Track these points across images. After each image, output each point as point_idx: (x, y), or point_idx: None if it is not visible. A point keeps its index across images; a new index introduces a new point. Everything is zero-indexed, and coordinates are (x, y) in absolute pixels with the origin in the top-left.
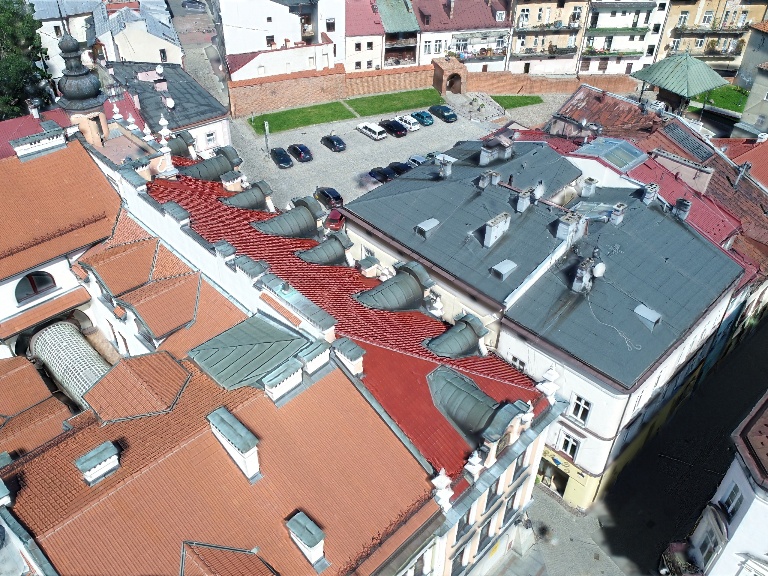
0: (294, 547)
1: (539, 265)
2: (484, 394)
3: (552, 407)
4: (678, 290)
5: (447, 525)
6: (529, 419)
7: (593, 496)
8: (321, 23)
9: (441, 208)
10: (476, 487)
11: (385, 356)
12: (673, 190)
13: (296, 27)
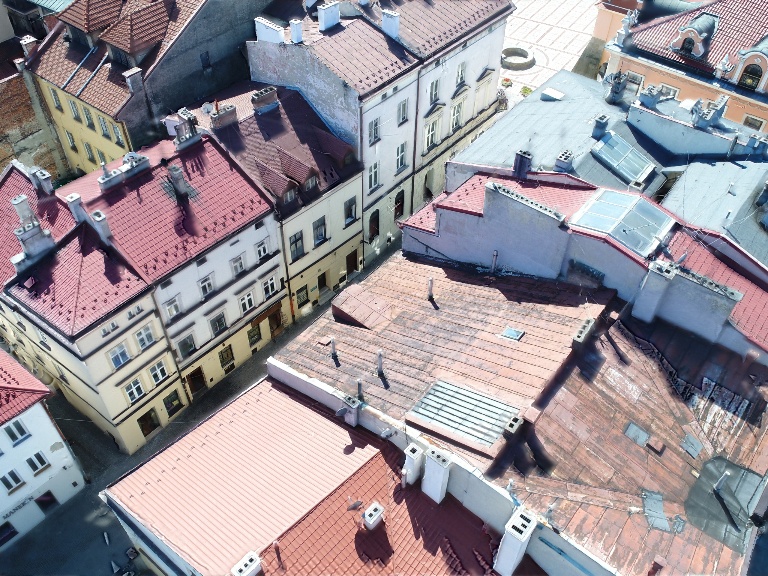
0: None
1: None
2: (665, 3)
3: None
4: (524, 122)
5: None
6: None
7: None
8: None
9: None
10: None
11: None
12: None
13: None
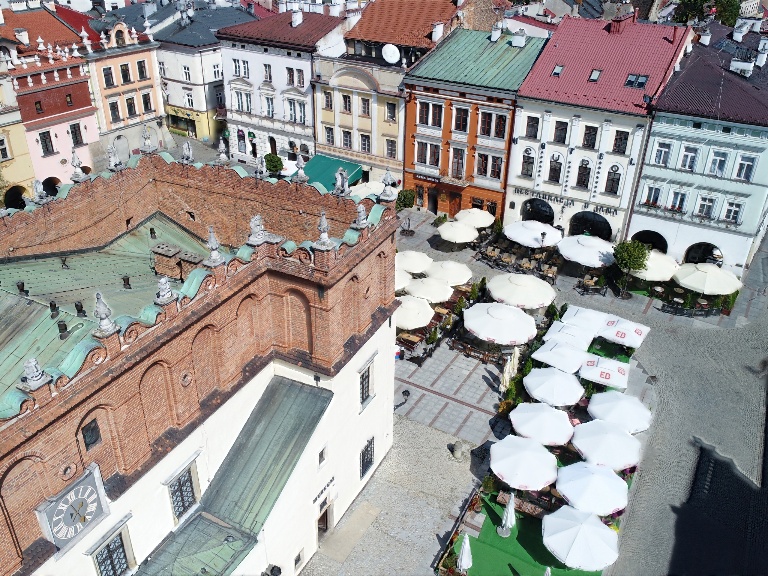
0: (18, 41)
1: (167, 18)
2: None
3: (152, 42)
4: None
5: (90, 55)
6: (135, 37)
7: (208, 130)
8: (108, 6)
9: (128, 12)
10: (107, 51)
11: (68, 11)
12: (255, 8)
13: (89, 8)
